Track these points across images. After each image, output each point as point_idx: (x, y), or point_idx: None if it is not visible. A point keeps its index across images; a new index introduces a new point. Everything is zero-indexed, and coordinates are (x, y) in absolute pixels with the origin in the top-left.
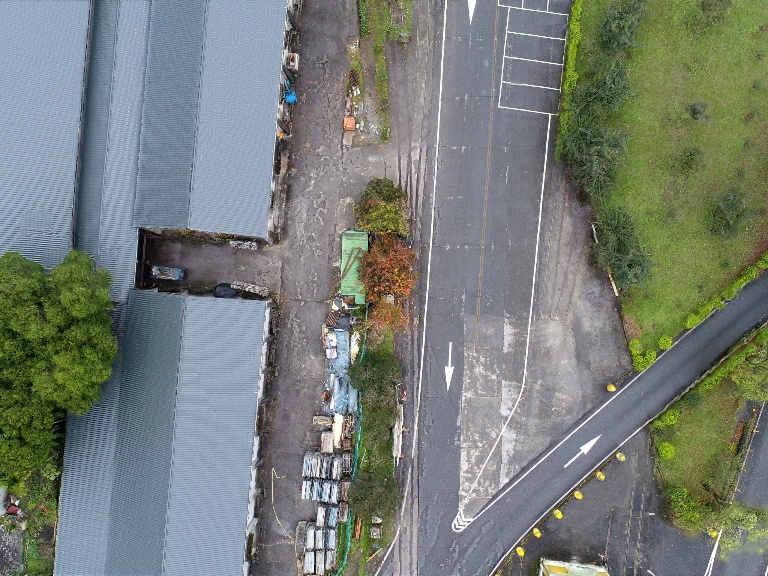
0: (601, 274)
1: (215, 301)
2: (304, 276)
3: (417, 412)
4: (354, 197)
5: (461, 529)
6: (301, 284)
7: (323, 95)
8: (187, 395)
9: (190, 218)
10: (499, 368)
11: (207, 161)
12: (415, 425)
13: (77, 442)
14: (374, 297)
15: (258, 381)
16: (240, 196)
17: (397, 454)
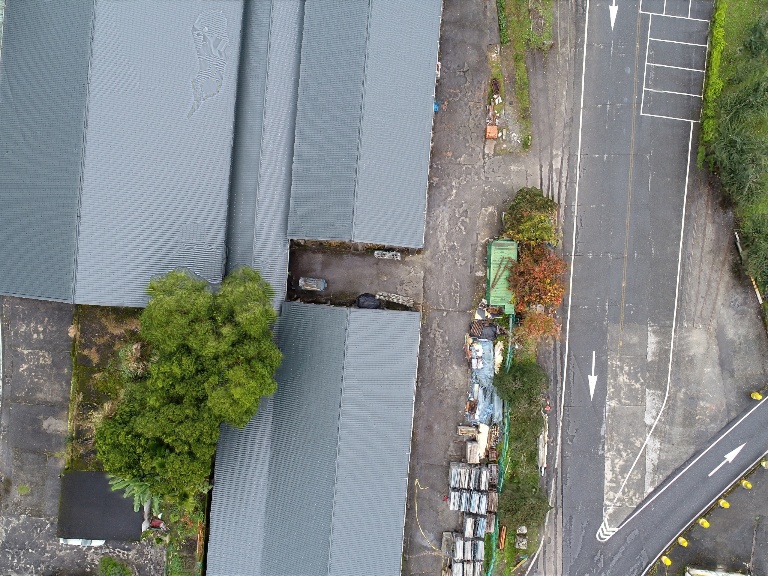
0: (744, 281)
1: (375, 313)
2: (446, 286)
3: (560, 421)
4: (496, 206)
5: (606, 539)
6: (443, 294)
7: (464, 103)
8: (350, 408)
9: (354, 230)
10: (643, 377)
11: (369, 172)
12: (558, 435)
13: (229, 455)
14: (523, 307)
15: (413, 393)
16: (398, 207)
17: (542, 464)
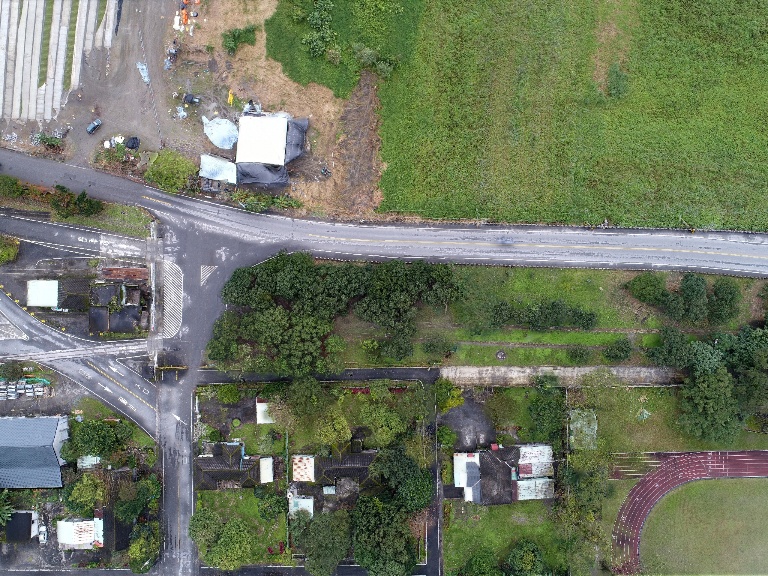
0: None
1: None
2: None
3: None
4: None
5: (28, 337)
6: None
7: None
8: None
9: None
10: None
11: None
12: None
13: None
14: None
15: None
16: None
17: None
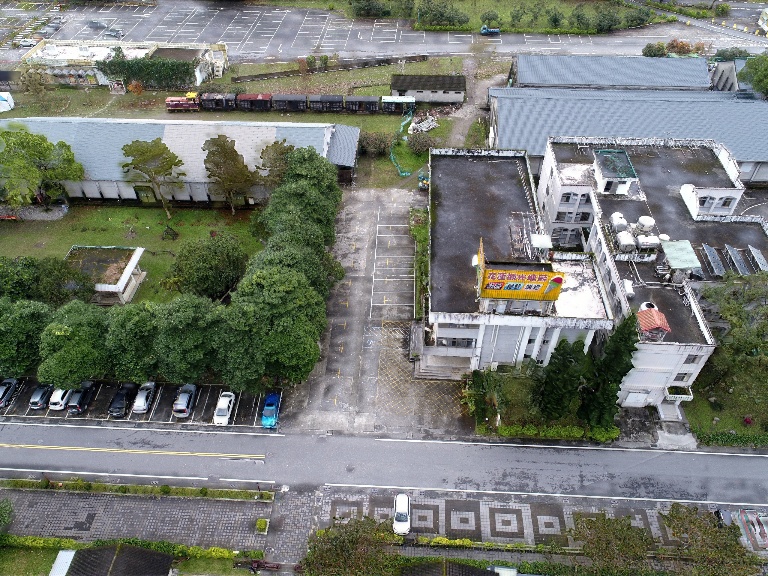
0: None
1: None
2: None
3: None
4: None
5: None
6: None
7: None
8: None
9: None
10: None
11: None
12: None
13: None
14: None
15: None
16: None
17: None
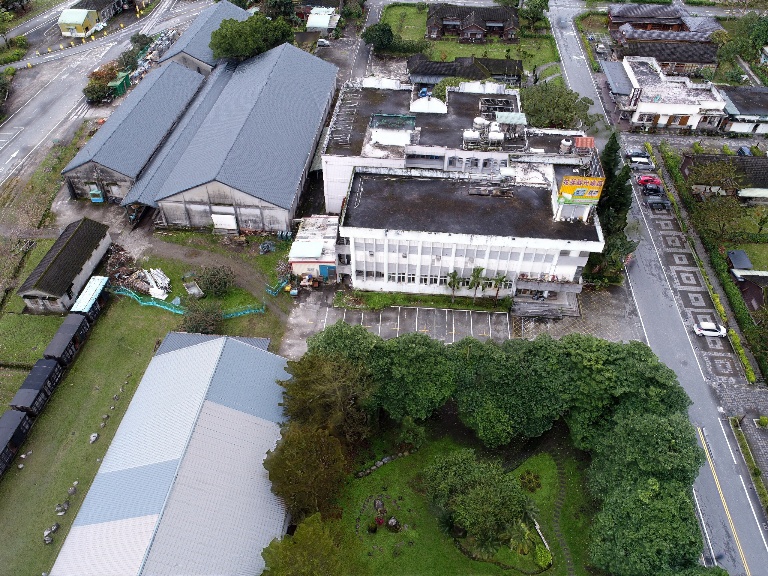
0: None
1: None
2: None
3: None
4: None
5: None
6: None
7: None
8: None
9: None
10: None
11: None
12: None
13: None
14: None
15: None
16: None
17: None
